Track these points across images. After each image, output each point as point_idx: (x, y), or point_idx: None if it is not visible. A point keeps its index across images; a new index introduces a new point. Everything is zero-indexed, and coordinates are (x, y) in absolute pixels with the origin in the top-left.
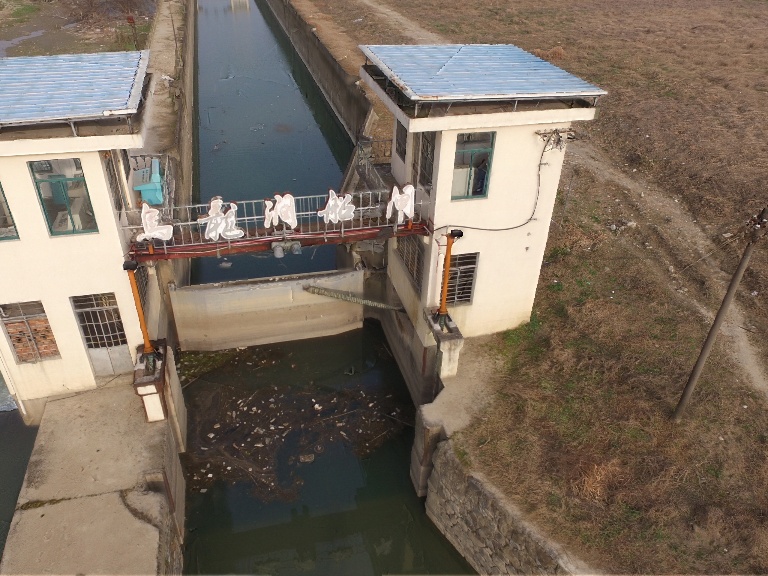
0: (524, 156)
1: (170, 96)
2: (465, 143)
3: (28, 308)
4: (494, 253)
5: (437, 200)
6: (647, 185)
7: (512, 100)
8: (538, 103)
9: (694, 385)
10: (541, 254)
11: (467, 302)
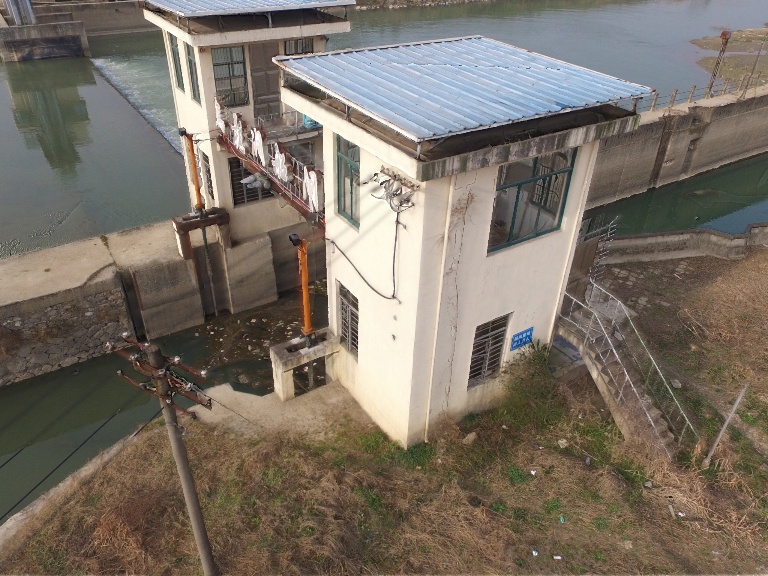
0: None
1: None
2: (537, 207)
3: None
4: None
5: None
6: None
7: None
8: None
9: None
10: None
11: None
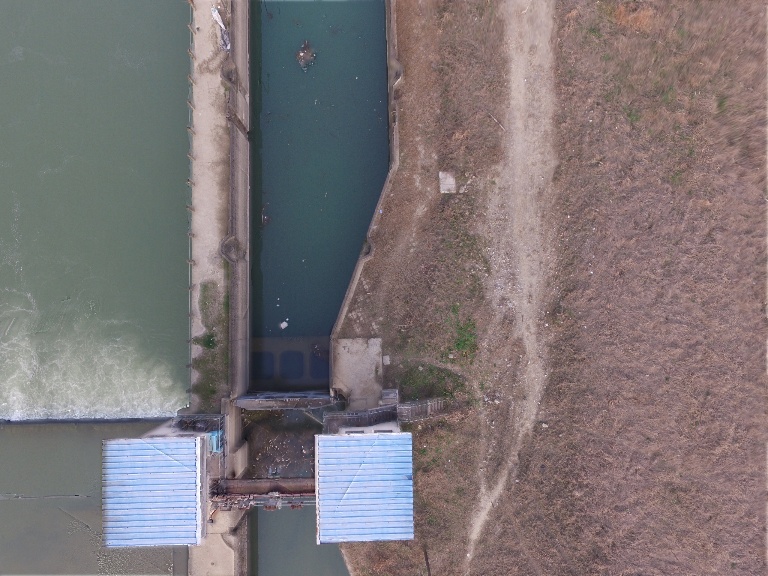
0: None
1: (222, 83)
2: None
3: None
4: None
5: None
6: (541, 349)
7: None
8: None
9: None
10: None
11: None
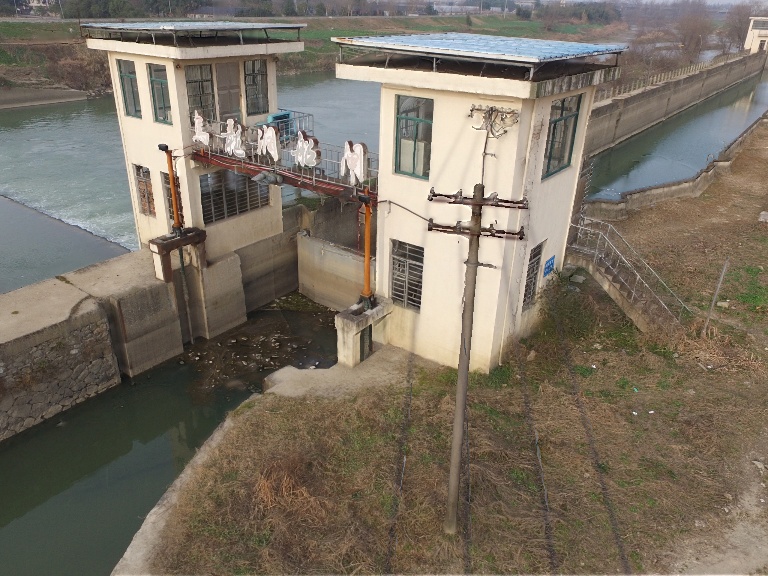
0: (467, 138)
1: None
2: None
3: (148, 173)
4: (439, 255)
5: (380, 167)
6: None
7: (429, 57)
8: (481, 72)
9: (452, 474)
10: (497, 281)
11: (419, 309)
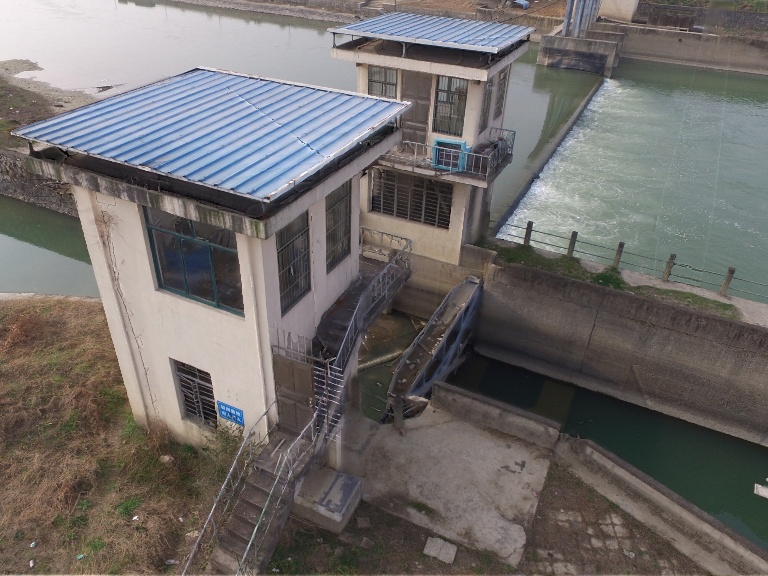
0: None
1: None
2: None
3: None
4: None
5: None
6: None
7: None
8: None
9: None
10: None
11: None
